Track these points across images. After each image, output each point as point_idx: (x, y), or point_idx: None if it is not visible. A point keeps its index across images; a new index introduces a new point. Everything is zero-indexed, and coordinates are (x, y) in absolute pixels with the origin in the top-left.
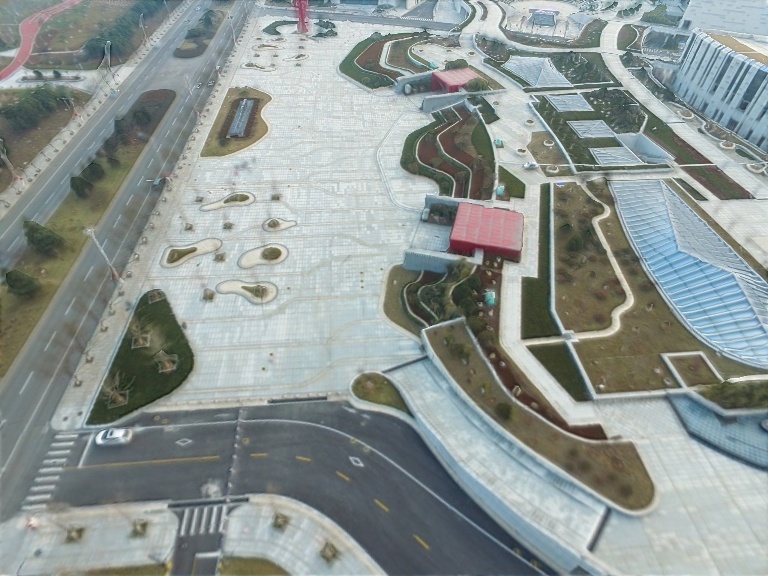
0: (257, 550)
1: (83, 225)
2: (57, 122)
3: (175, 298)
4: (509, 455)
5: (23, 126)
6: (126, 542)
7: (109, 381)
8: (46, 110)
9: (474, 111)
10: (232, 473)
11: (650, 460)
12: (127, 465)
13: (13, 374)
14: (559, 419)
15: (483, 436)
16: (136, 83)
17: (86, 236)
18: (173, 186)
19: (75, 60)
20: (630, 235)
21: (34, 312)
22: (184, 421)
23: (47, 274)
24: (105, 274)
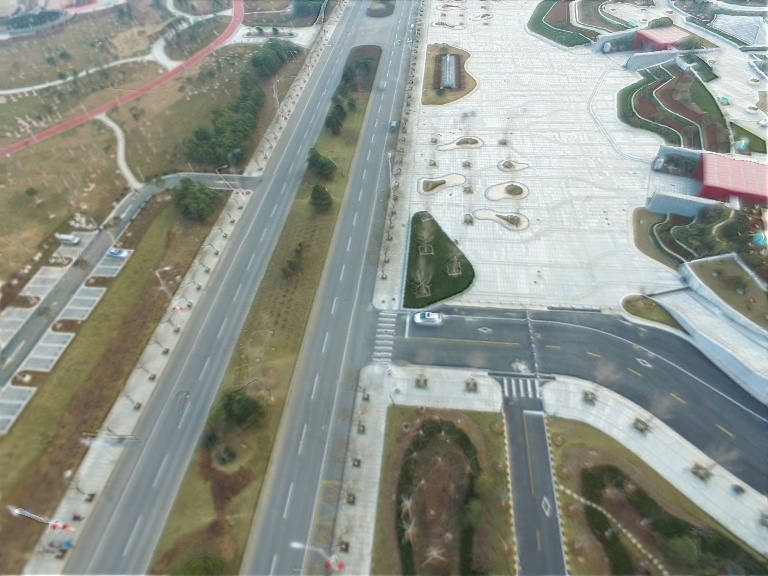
0: (575, 415)
1: (343, 156)
2: (289, 71)
3: (440, 220)
4: None
5: (267, 73)
6: (464, 394)
7: (410, 277)
8: (280, 61)
9: (687, 69)
10: (535, 357)
11: None
12: (444, 340)
13: (330, 265)
14: None
15: None
16: (342, 39)
17: (348, 165)
18: (407, 128)
19: (284, 19)
20: None
21: (329, 221)
22: (479, 314)
23: (329, 193)
24: (374, 196)
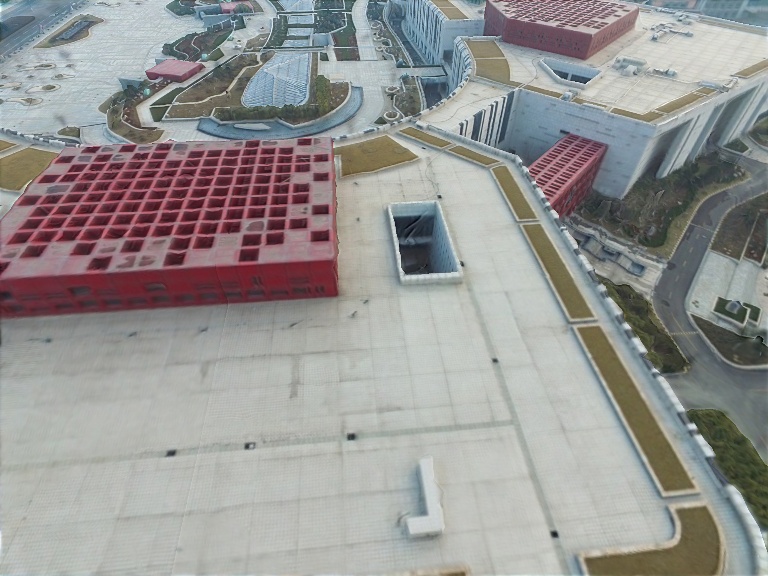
0: None
1: None
2: None
3: None
4: None
5: None
6: None
7: None
8: None
9: (233, 24)
10: None
11: (168, 135)
12: None
13: None
14: (137, 125)
15: (104, 137)
16: (10, 13)
17: None
18: (5, 61)
19: None
20: (257, 72)
21: None
22: None
23: None
24: None
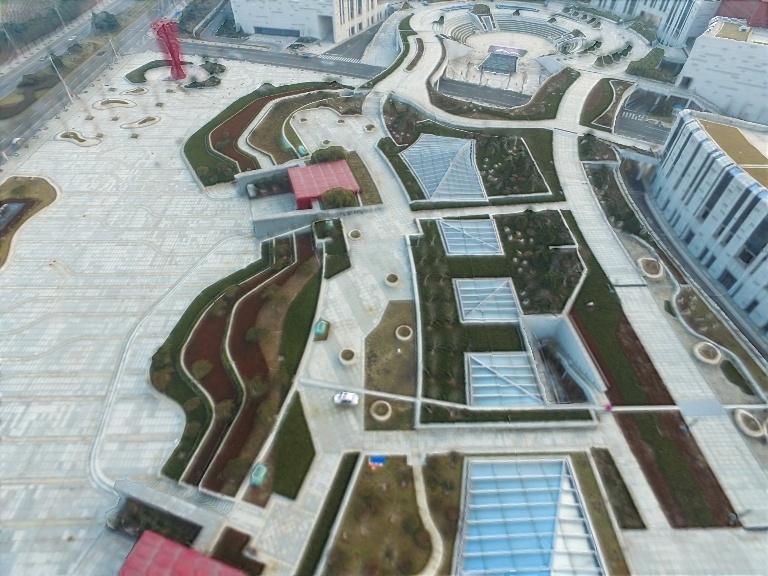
0: None
1: None
2: None
3: None
4: None
5: None
6: None
7: None
8: None
9: (319, 247)
10: None
11: None
12: None
13: None
14: None
15: None
16: None
17: None
18: None
19: None
20: None
21: None
22: None
23: None
24: None
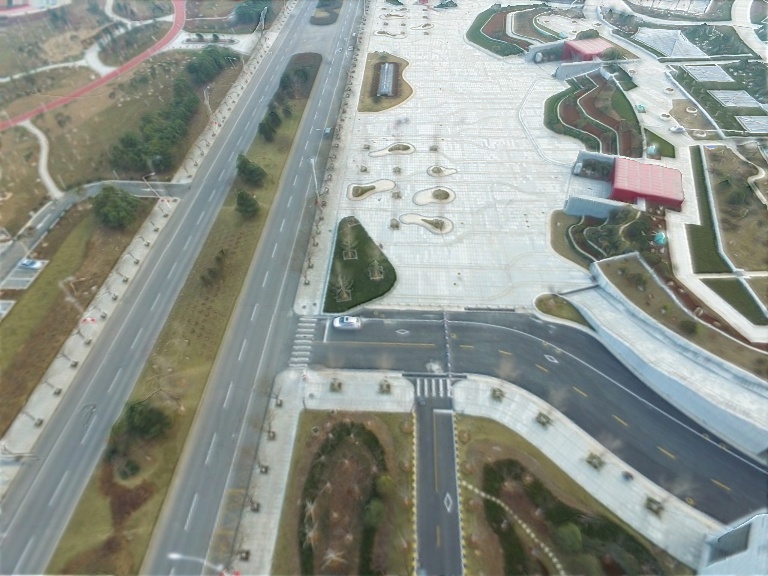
0: (483, 412)
1: (275, 163)
2: (227, 78)
3: (367, 225)
4: (694, 362)
5: (203, 80)
6: (377, 396)
7: (332, 282)
8: (218, 67)
9: (610, 79)
10: (449, 357)
11: None
12: (362, 344)
13: (253, 272)
14: (742, 336)
15: (666, 347)
16: (284, 47)
17: (280, 172)
18: (341, 135)
19: (226, 25)
20: None
21: (256, 227)
22: (398, 317)
23: (258, 199)
24: (303, 202)
